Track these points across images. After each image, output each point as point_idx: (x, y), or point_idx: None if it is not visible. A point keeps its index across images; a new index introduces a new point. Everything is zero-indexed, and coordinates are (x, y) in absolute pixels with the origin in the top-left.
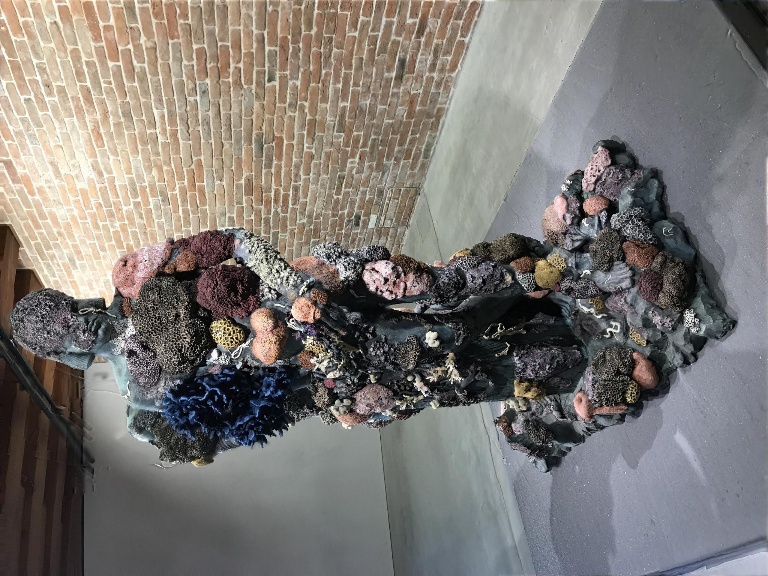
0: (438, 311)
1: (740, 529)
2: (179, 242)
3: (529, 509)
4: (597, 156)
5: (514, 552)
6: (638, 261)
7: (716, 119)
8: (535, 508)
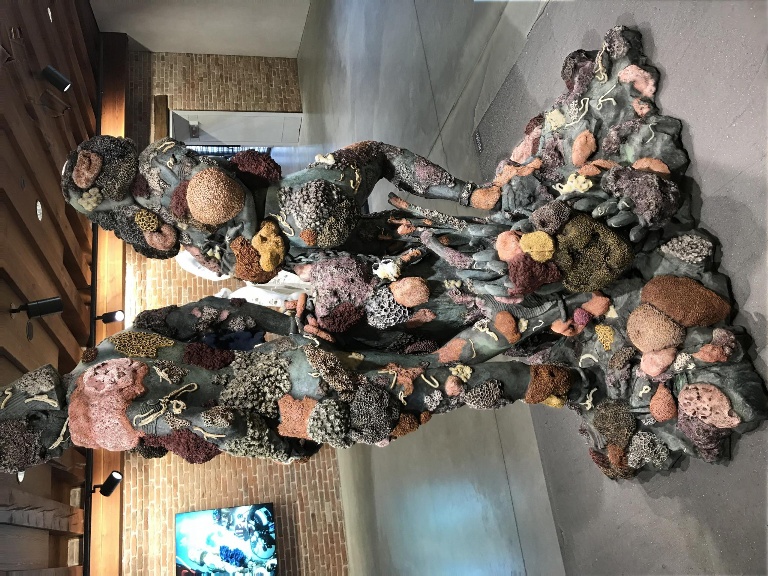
0: (454, 301)
1: (536, 416)
2: (149, 445)
3: (507, 108)
4: (725, 416)
5: (499, 9)
6: (610, 458)
7: (749, 568)
8: (509, 122)
